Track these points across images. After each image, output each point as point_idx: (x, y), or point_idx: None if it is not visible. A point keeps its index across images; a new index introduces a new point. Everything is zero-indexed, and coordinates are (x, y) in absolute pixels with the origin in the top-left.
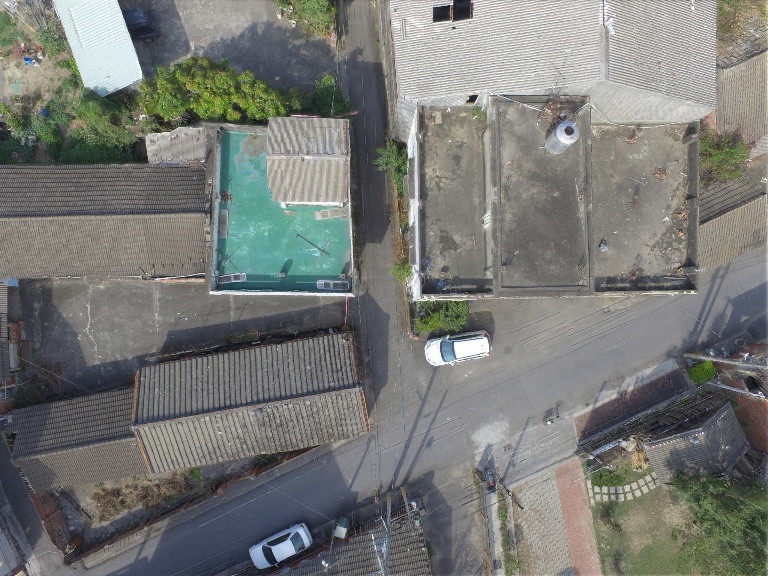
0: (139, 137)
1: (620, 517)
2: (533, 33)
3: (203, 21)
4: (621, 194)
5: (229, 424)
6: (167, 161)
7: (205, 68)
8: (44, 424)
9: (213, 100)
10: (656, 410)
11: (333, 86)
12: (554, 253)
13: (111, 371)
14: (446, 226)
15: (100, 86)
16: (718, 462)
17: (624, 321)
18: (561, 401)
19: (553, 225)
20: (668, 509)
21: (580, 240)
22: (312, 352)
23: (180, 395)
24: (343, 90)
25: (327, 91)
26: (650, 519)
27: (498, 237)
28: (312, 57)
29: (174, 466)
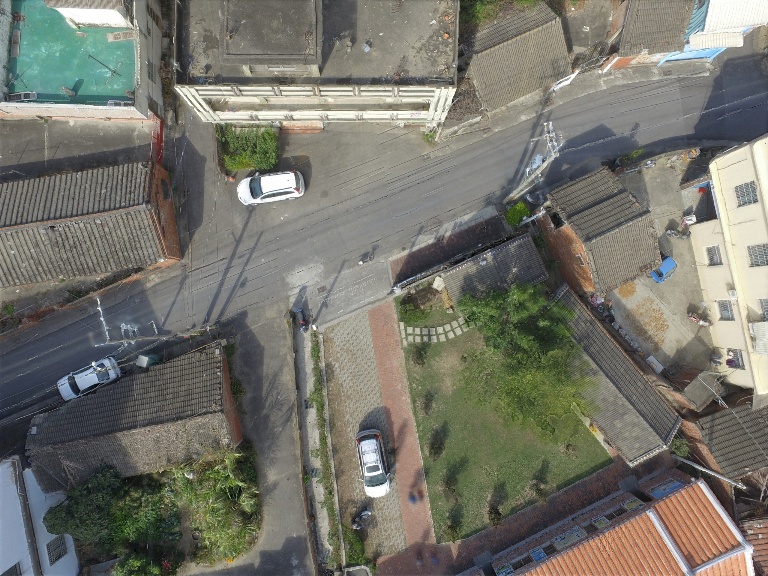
0: None
1: (432, 358)
2: None
3: None
4: None
5: (21, 243)
6: None
7: None
8: None
9: None
10: None
11: None
12: (281, 22)
13: None
14: (210, 26)
15: None
16: (505, 282)
17: (443, 167)
18: (377, 245)
19: None
20: (481, 351)
21: (308, 10)
22: (110, 178)
23: None
24: None
25: None
26: None
27: (225, 6)
28: None
29: None
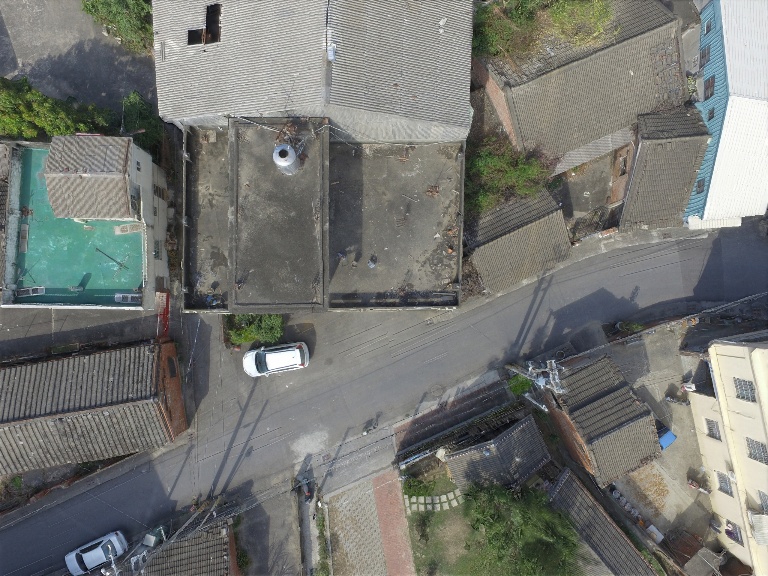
0: None
1: (436, 527)
2: (269, 57)
3: (31, 38)
4: (393, 211)
5: (30, 434)
6: None
7: None
8: None
9: (2, 119)
10: None
11: (139, 103)
12: (289, 271)
13: None
14: (217, 242)
15: None
16: (508, 474)
17: (446, 333)
18: (381, 412)
19: (289, 244)
20: None
21: (315, 258)
22: (117, 364)
23: None
24: None
25: (135, 108)
26: (466, 529)
27: (233, 256)
28: (138, 73)
29: None
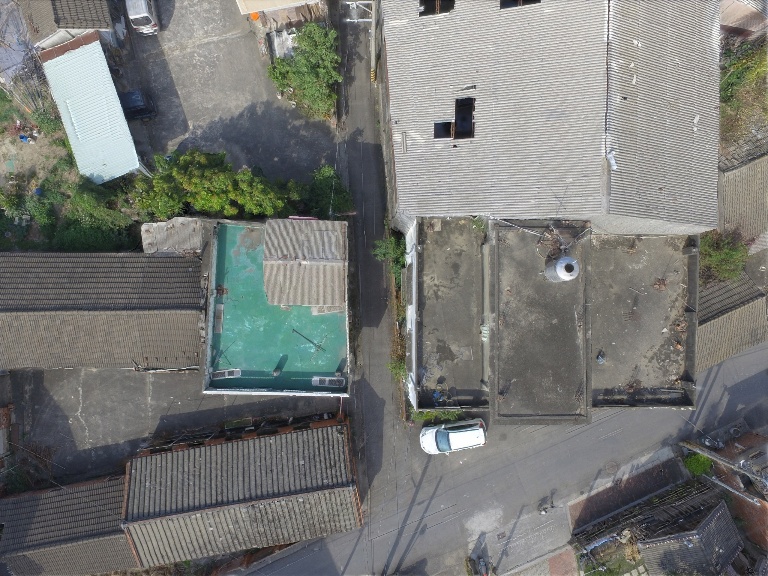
0: (135, 220)
1: None
2: (534, 159)
3: (202, 100)
4: (620, 305)
5: (220, 520)
6: (163, 250)
7: (203, 165)
8: (32, 517)
9: (210, 199)
10: (651, 515)
11: (332, 177)
12: (552, 381)
13: (102, 455)
14: (443, 336)
15: (96, 173)
16: (712, 566)
17: None
18: (556, 489)
19: (551, 352)
20: None
21: (578, 368)
22: (306, 445)
23: (171, 490)
24: (342, 171)
25: (326, 181)
26: None
27: (495, 364)
28: (312, 138)
29: (164, 560)
